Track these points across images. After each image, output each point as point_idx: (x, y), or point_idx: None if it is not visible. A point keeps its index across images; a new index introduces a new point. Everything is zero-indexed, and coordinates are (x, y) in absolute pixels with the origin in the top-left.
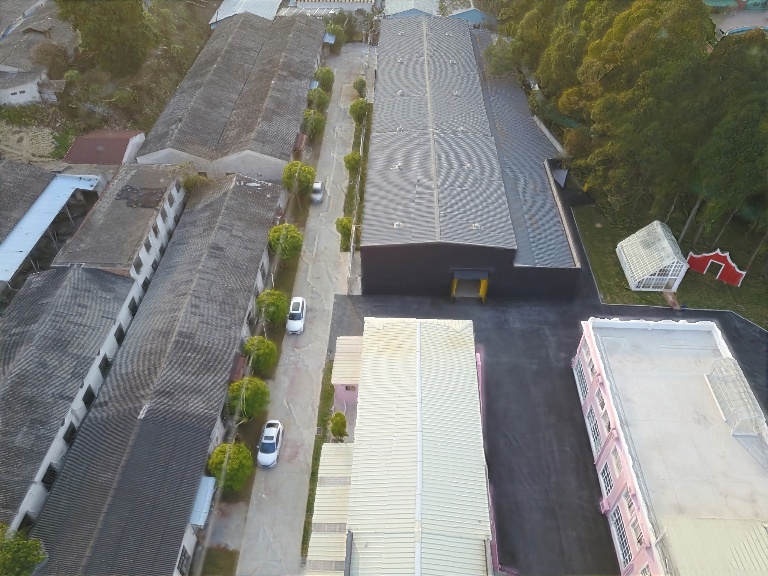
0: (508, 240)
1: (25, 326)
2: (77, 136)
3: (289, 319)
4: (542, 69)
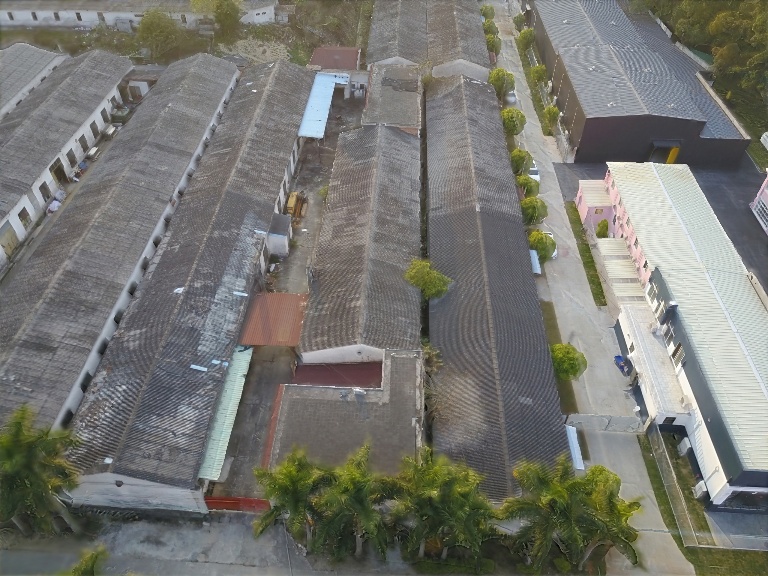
0: (698, 116)
1: (365, 159)
2: (304, 51)
3: (529, 174)
4: (690, 1)
